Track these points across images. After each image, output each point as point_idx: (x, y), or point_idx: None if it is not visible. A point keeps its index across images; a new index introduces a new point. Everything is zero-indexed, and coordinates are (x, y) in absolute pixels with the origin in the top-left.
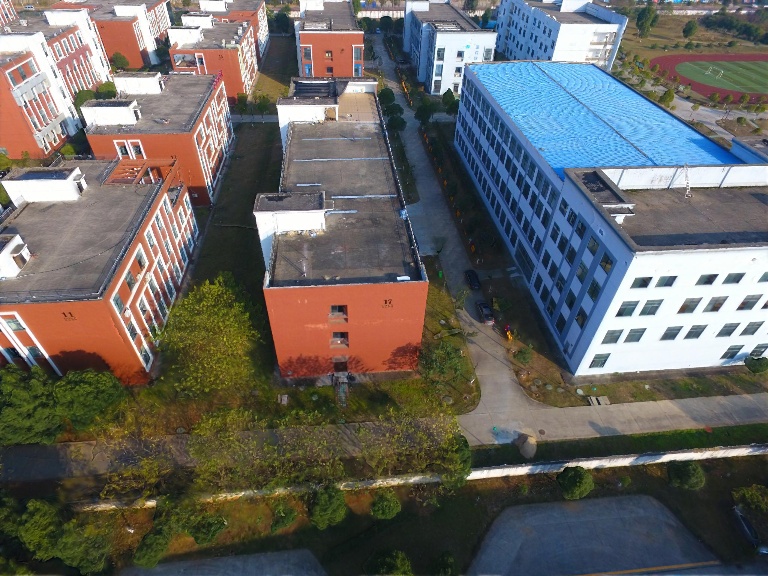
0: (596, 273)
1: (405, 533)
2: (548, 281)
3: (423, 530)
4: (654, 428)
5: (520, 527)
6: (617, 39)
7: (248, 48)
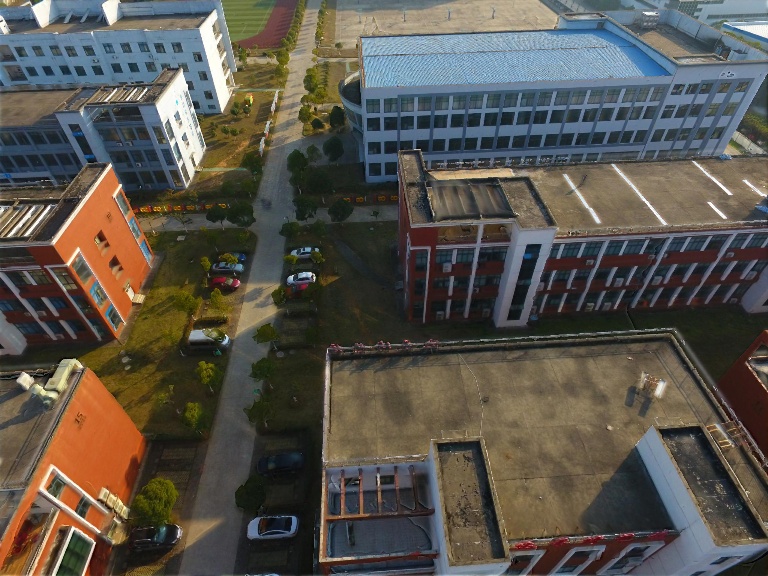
0: None
1: None
2: (666, 145)
3: None
4: (735, 150)
5: None
6: (221, 25)
7: None
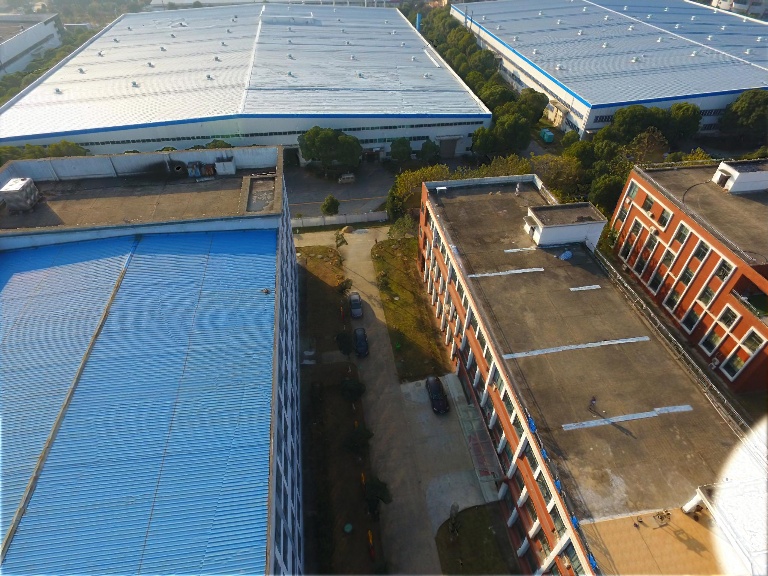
0: None
1: (417, 205)
2: None
3: (409, 206)
4: None
5: (360, 211)
6: None
7: None
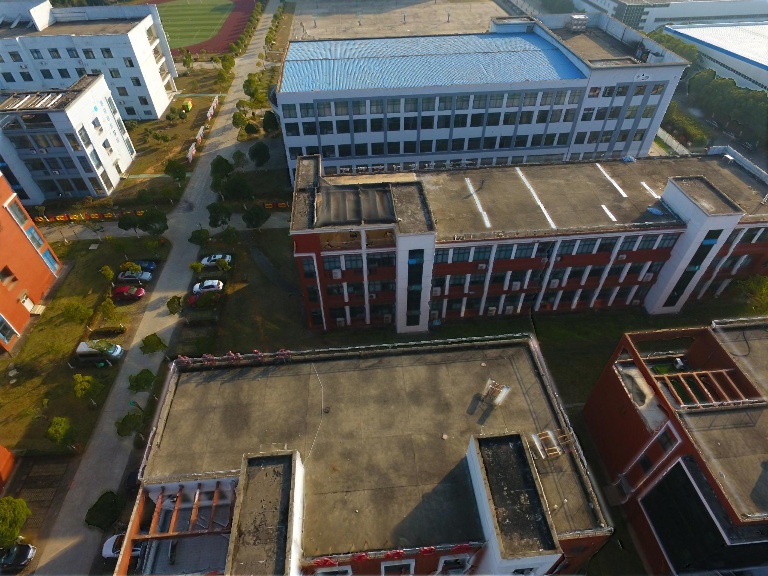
0: (650, 101)
1: None
2: (589, 147)
3: None
4: None
5: None
6: (157, 30)
7: None
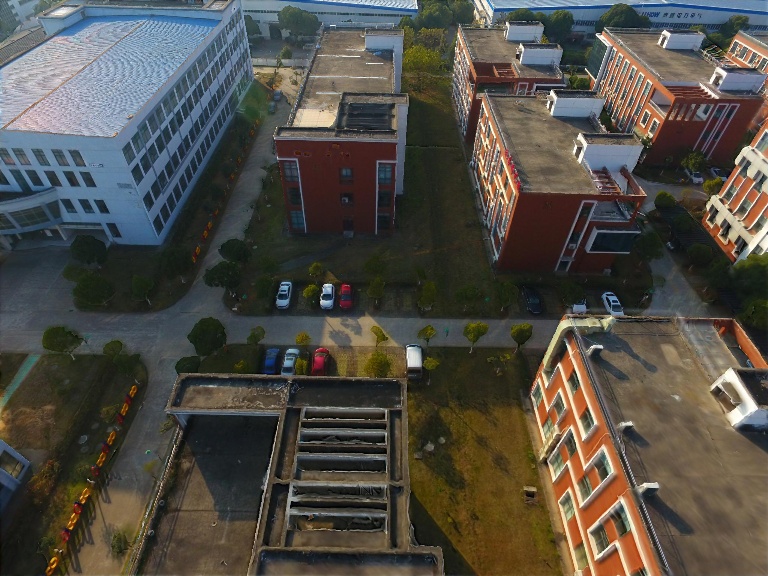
0: None
1: None
2: None
3: None
4: None
5: None
6: None
7: (617, 543)
